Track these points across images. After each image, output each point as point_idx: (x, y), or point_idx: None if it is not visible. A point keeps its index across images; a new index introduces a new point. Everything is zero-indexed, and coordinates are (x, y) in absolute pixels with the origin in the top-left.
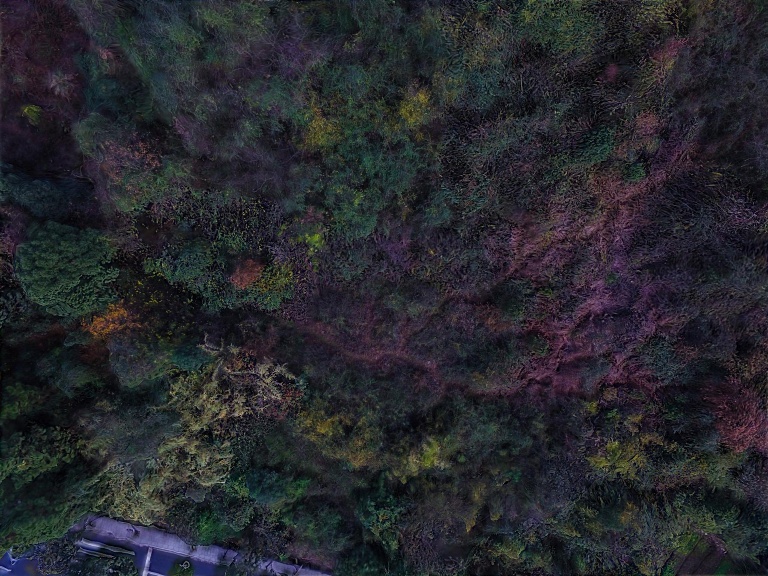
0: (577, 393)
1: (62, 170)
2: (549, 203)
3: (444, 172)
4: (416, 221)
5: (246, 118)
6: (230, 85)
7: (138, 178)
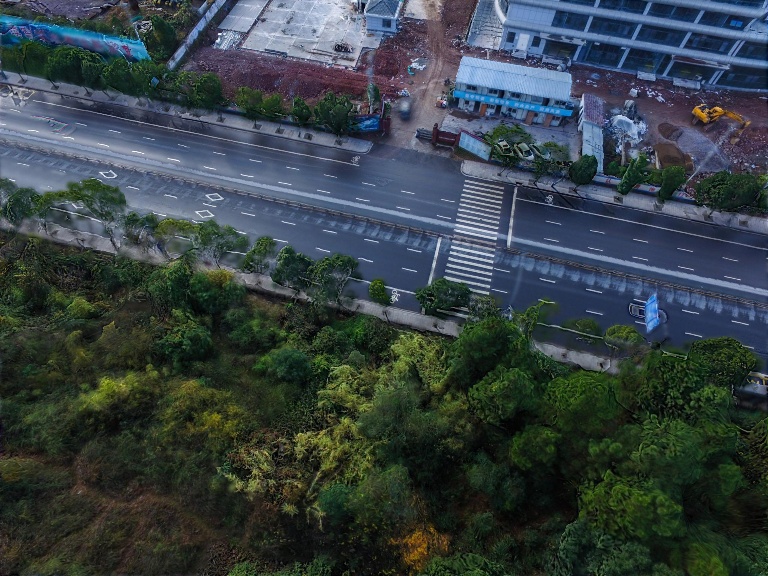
0: None
1: None
2: None
3: None
4: None
5: None
6: None
7: None
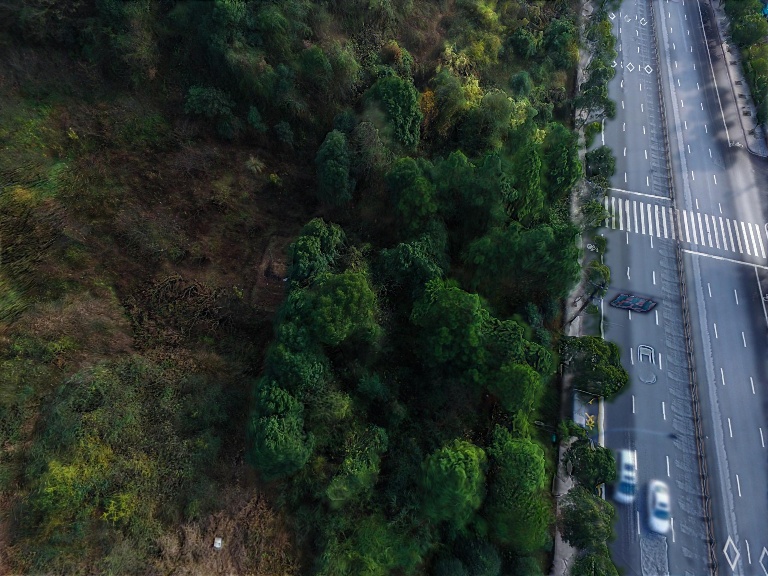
0: None
1: None
2: None
3: None
4: None
5: None
6: None
7: None
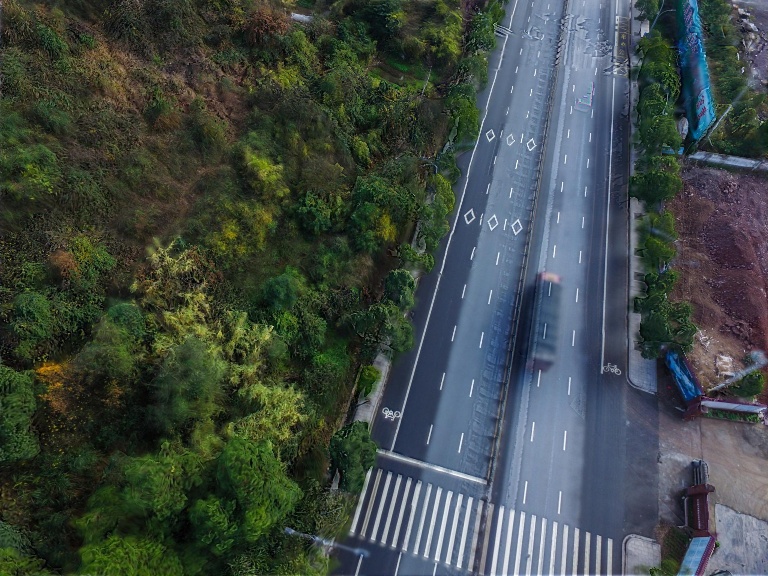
0: (241, 96)
1: None
2: None
3: None
4: (60, 132)
5: None
6: None
7: None
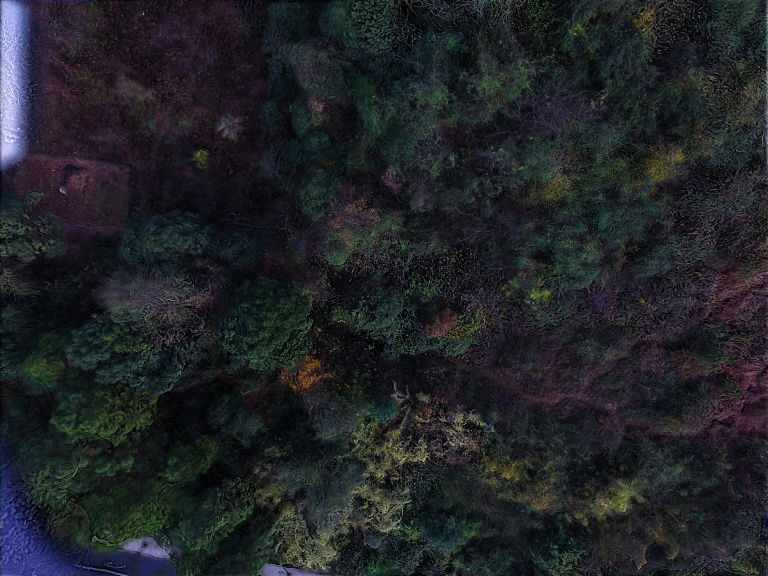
0: (760, 433)
1: (228, 214)
2: (756, 250)
3: (673, 225)
4: (633, 272)
5: (487, 176)
6: (491, 147)
7: (355, 232)
